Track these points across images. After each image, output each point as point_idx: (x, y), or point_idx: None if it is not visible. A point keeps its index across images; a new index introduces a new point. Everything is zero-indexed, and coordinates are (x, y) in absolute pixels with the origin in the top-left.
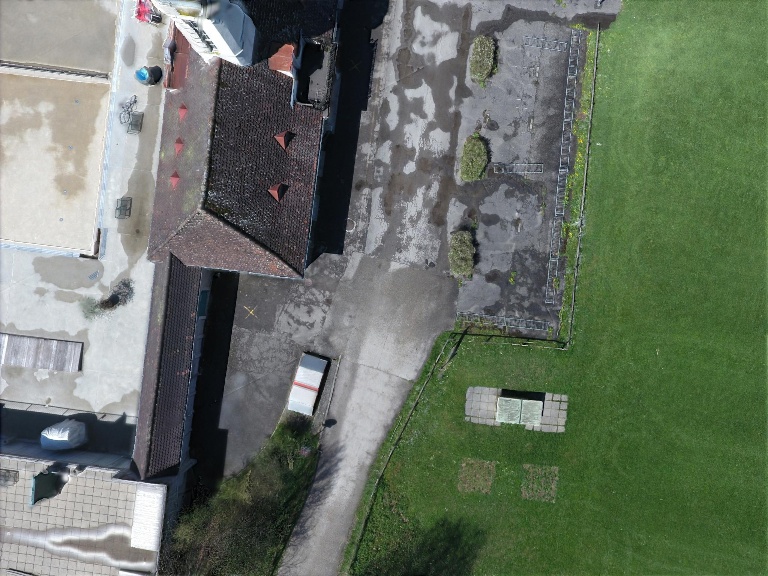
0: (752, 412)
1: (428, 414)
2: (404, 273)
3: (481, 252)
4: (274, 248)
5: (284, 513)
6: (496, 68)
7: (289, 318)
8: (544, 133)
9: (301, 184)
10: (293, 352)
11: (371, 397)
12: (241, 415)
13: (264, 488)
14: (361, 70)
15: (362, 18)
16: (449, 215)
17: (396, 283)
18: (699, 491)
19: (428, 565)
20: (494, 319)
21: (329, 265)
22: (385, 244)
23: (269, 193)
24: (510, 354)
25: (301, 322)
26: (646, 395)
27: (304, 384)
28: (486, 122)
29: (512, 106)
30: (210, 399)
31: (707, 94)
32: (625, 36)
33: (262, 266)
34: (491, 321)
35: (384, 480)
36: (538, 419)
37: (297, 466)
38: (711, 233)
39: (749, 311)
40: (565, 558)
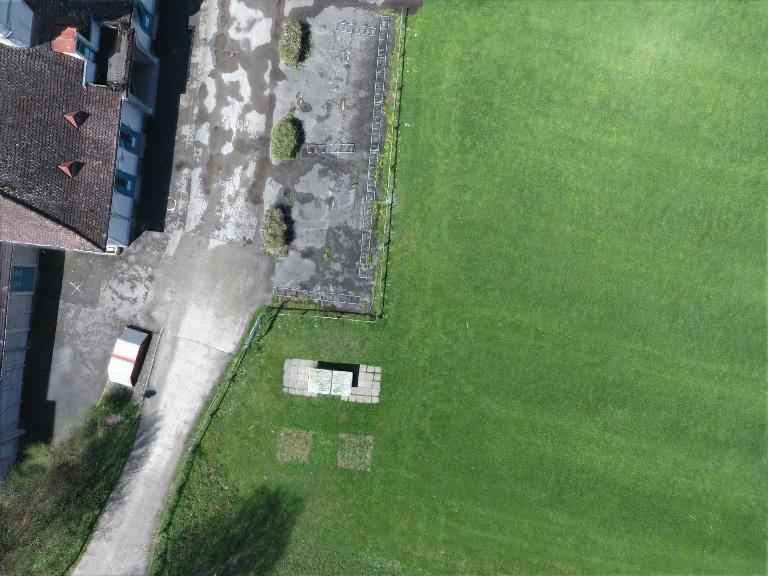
0: (559, 383)
1: (246, 385)
2: (223, 250)
3: (296, 229)
4: (69, 222)
5: (102, 480)
6: (308, 52)
7: (113, 293)
8: (355, 114)
9: (99, 162)
10: (117, 326)
11: (190, 369)
12: (68, 387)
13: (86, 456)
14: (180, 55)
15: (180, 5)
16: (265, 194)
17: (215, 259)
18: (510, 460)
19: (247, 531)
20: (309, 294)
21: (151, 242)
22: (204, 222)
23: (60, 169)
24: (325, 327)
25: (125, 297)
26: (457, 367)
27: (122, 356)
28: (300, 104)
29: (324, 89)
30: (36, 371)
31: (510, 76)
32: (431, 21)
33: (63, 240)
34: (306, 295)
35: (201, 449)
36: (348, 389)
37: (117, 435)
38: (516, 210)
39: (554, 285)
40: (381, 525)
